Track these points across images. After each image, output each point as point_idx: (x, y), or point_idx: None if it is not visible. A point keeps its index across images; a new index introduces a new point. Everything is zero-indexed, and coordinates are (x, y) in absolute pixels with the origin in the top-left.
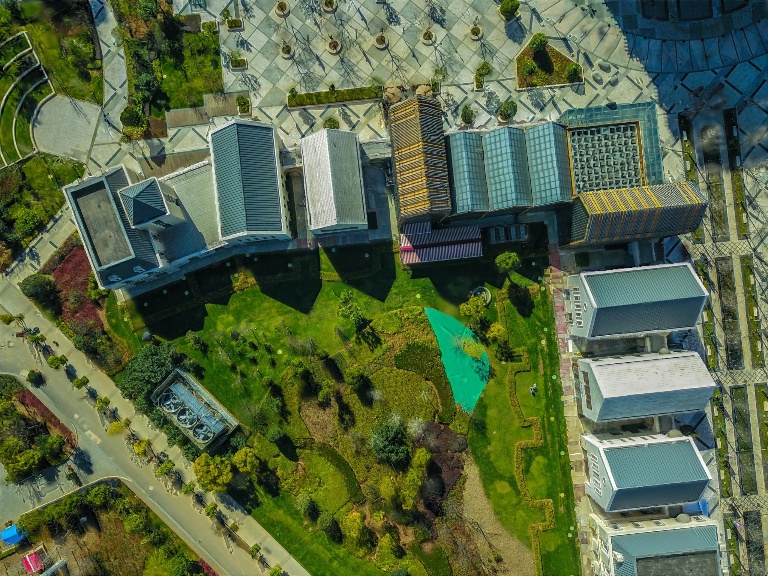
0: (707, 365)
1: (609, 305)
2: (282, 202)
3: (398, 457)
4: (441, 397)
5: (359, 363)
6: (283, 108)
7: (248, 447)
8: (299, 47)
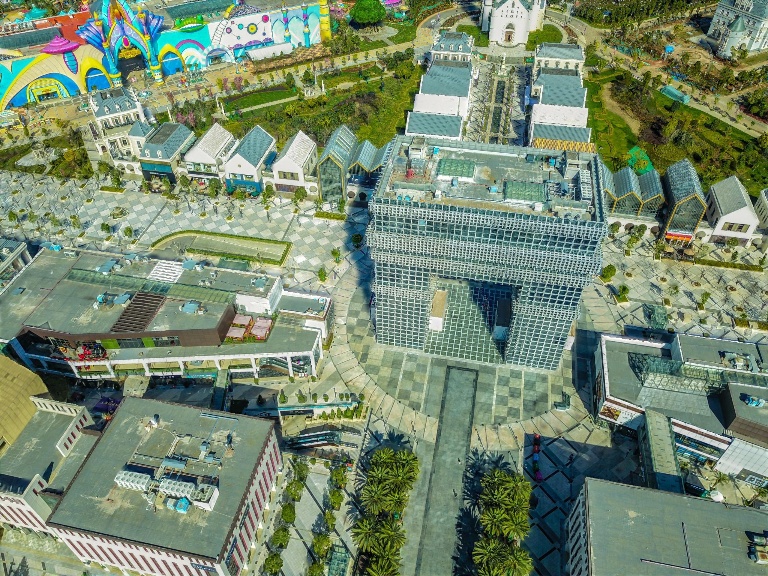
0: (509, 140)
1: (583, 128)
2: (766, 201)
3: (680, 132)
4: (653, 151)
5: (701, 168)
6: (765, 268)
7: (763, 149)
8: (759, 295)
